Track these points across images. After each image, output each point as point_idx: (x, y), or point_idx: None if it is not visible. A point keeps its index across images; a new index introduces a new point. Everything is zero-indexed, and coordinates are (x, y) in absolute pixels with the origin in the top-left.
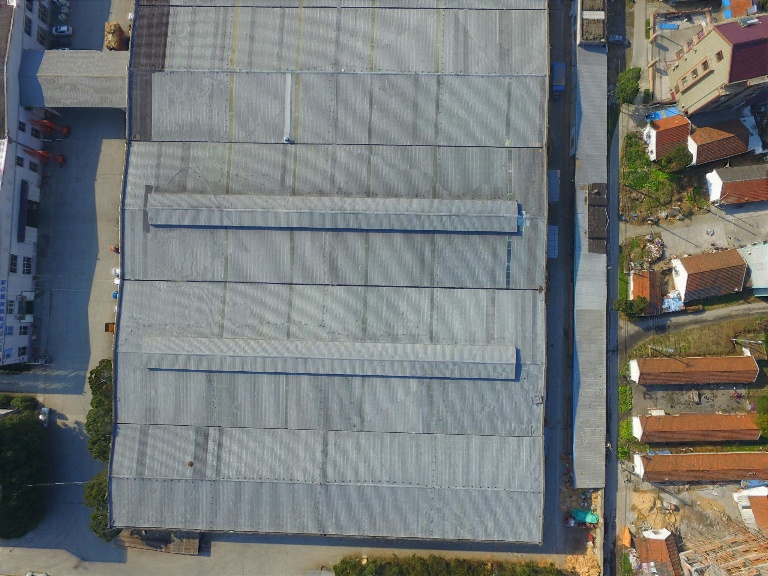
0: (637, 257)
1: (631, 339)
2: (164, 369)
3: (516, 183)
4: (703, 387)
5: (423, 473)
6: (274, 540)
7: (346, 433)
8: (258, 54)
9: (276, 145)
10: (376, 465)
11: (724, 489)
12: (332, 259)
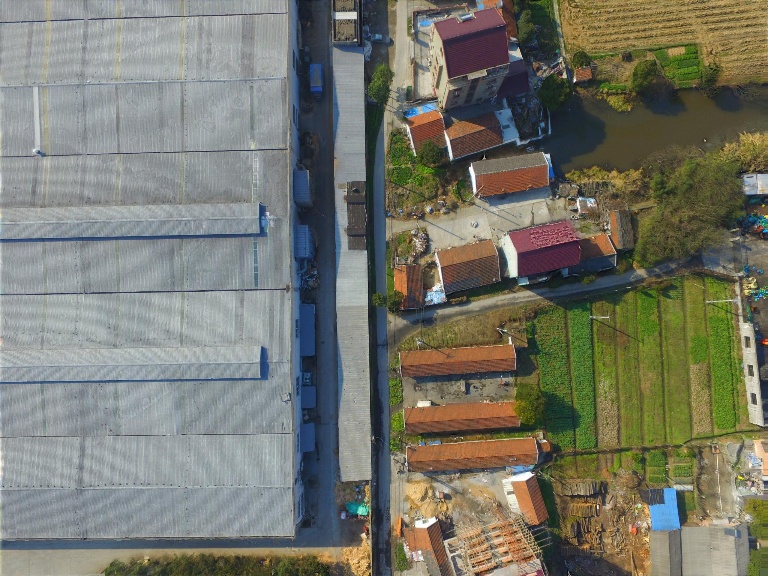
0: (404, 252)
1: (400, 333)
2: None
3: (261, 185)
4: (471, 377)
5: (177, 474)
6: (58, 546)
7: (103, 438)
8: (6, 69)
9: (28, 158)
10: (131, 468)
11: (494, 476)
12: (84, 268)
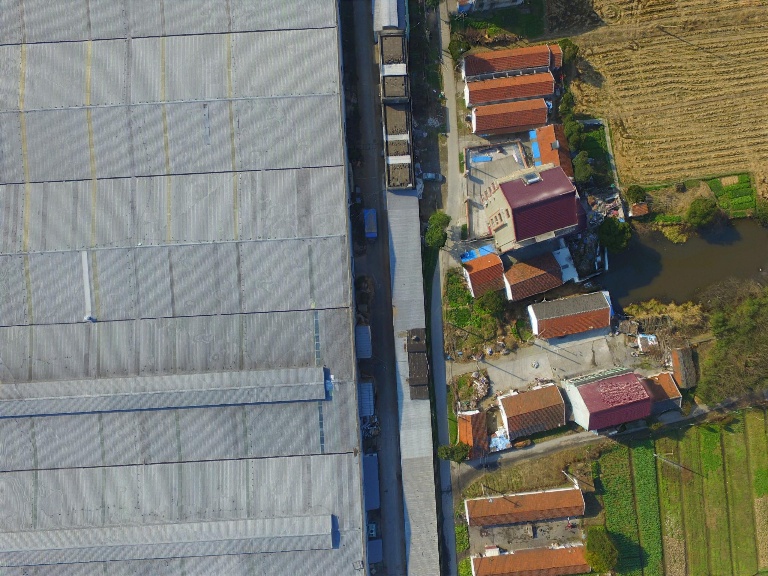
0: (465, 395)
1: (464, 478)
2: None
3: (324, 346)
4: (538, 520)
5: None
6: None
7: None
8: (52, 233)
9: (78, 324)
10: None
11: None
12: (143, 438)
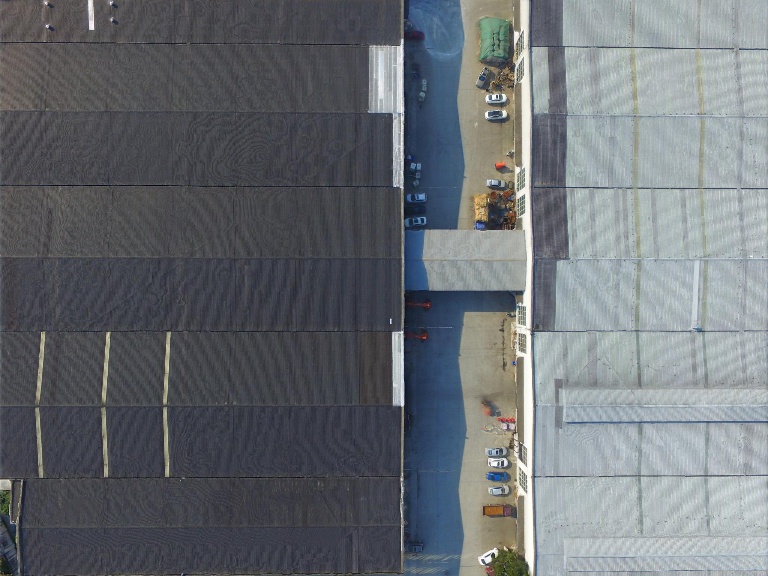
0: None
1: None
2: None
3: None
4: None
5: None
6: None
7: None
8: (664, 240)
9: (683, 333)
10: None
11: None
12: (747, 450)
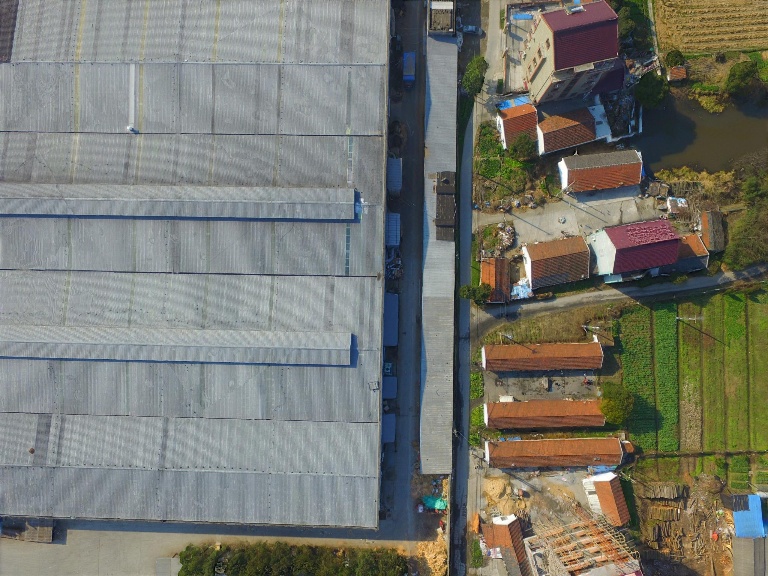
0: (489, 245)
1: (483, 326)
2: (6, 357)
3: (356, 171)
4: (554, 374)
5: (260, 459)
6: (129, 528)
7: (186, 420)
8: (103, 45)
9: (121, 135)
10: (214, 451)
11: (574, 475)
12: (174, 247)
